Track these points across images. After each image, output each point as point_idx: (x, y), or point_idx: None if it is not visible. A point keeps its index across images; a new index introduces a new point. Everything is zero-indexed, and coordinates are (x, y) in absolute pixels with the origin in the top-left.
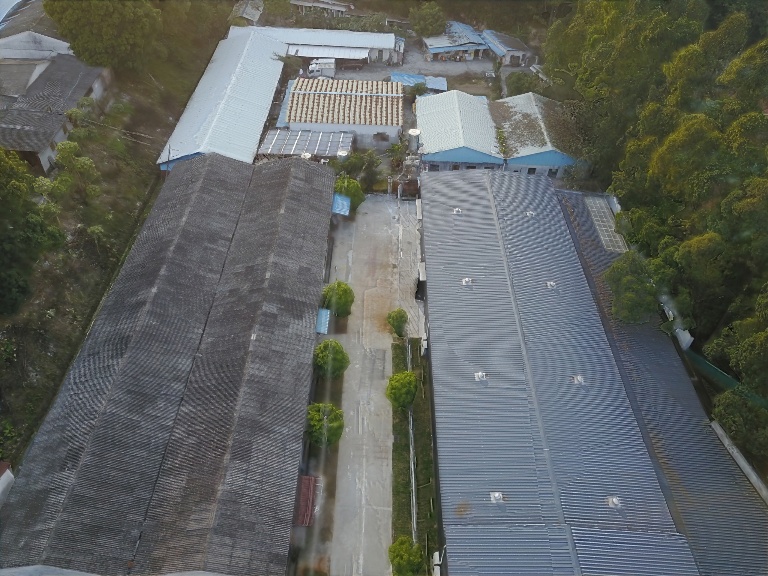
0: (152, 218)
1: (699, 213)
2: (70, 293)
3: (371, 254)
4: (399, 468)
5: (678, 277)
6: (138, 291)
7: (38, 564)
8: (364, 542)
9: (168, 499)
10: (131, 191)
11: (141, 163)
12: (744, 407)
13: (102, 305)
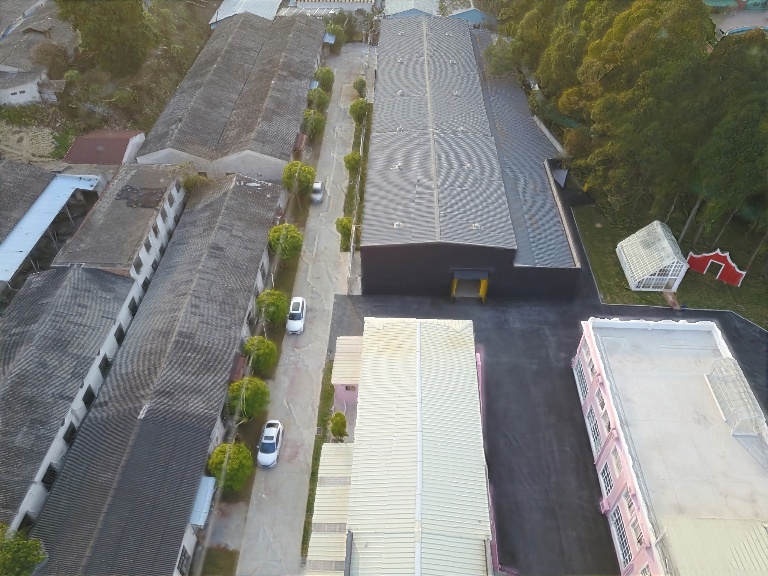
0: (209, 43)
1: (533, 6)
2: (162, 80)
3: (349, 70)
4: (356, 149)
5: (525, 49)
6: (205, 68)
7: (168, 148)
8: (334, 172)
9: (229, 137)
10: (193, 38)
11: (198, 25)
12: (543, 96)
13: (184, 77)
